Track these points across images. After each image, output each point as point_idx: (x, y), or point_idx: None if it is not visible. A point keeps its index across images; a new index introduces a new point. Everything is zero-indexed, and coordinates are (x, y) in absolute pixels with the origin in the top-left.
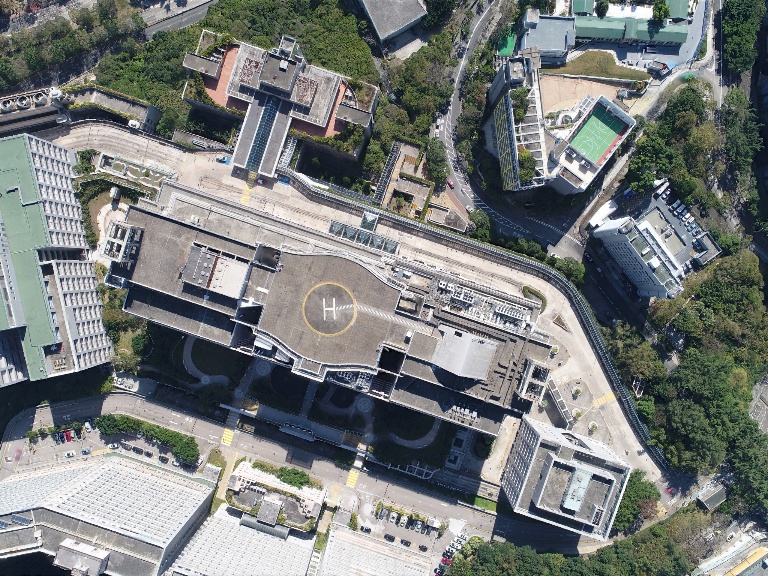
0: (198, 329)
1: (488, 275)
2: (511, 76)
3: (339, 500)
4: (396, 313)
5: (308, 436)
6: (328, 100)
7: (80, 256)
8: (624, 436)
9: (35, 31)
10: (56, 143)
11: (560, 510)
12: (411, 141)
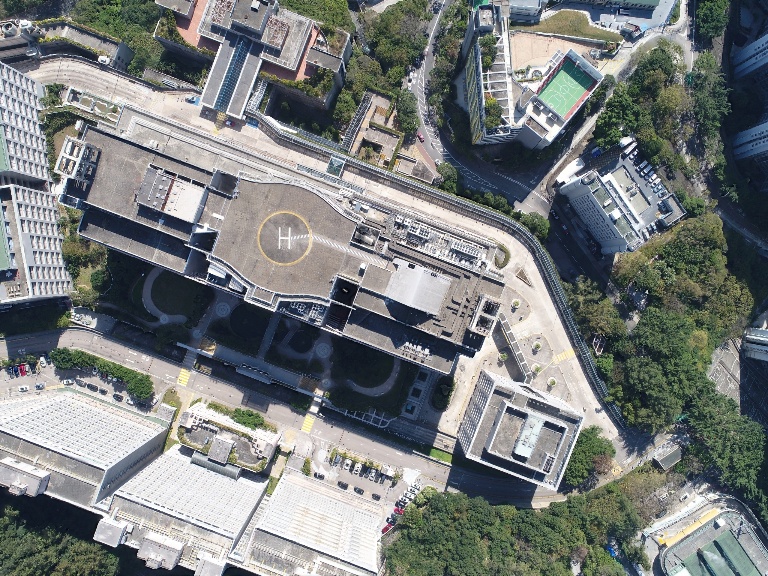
0: (152, 255)
1: None
2: (480, 23)
3: (293, 445)
4: (351, 245)
5: (265, 379)
6: (299, 43)
7: (42, 188)
8: (582, 393)
9: None
10: None
11: (511, 456)
12: (382, 92)
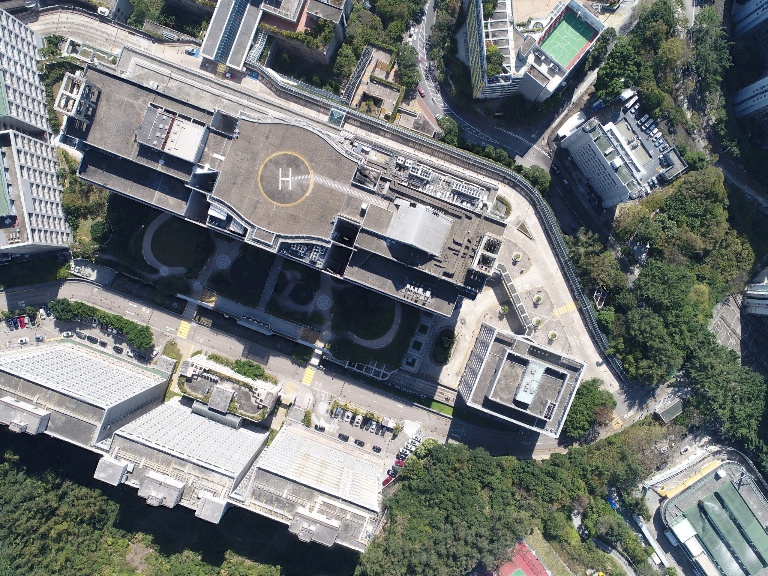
0: (153, 197)
1: None
2: None
3: (294, 397)
4: (352, 185)
5: (265, 330)
6: None
7: (41, 138)
8: (583, 347)
9: None
10: None
11: (513, 403)
12: (383, 46)
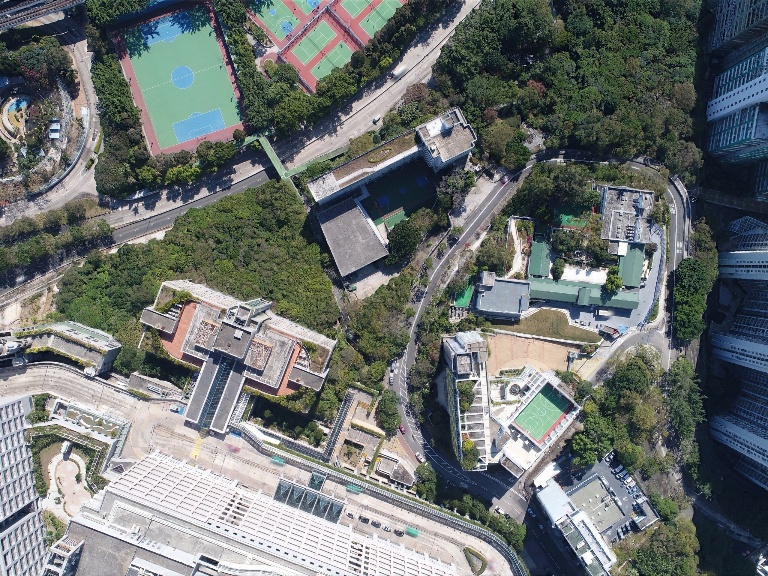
0: None
1: (431, 534)
2: (458, 370)
3: None
4: None
5: None
6: (282, 363)
7: (29, 509)
8: None
9: (1, 232)
10: (12, 380)
11: None
12: (364, 389)
